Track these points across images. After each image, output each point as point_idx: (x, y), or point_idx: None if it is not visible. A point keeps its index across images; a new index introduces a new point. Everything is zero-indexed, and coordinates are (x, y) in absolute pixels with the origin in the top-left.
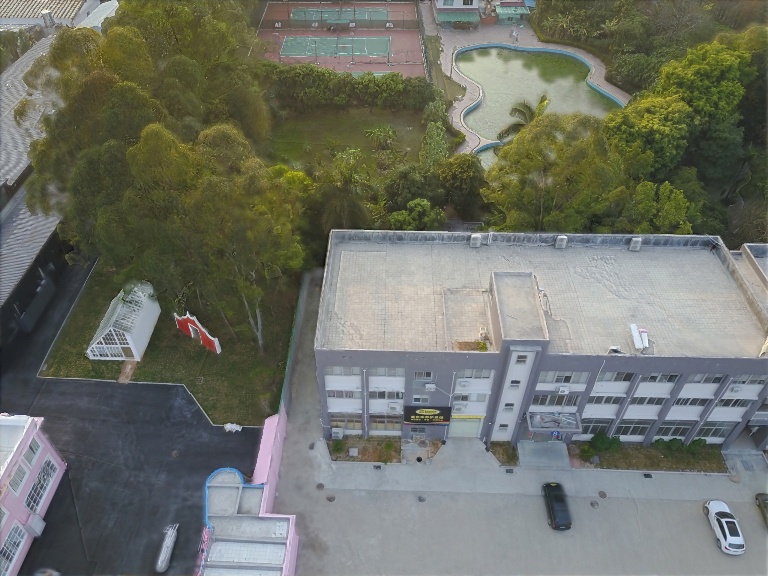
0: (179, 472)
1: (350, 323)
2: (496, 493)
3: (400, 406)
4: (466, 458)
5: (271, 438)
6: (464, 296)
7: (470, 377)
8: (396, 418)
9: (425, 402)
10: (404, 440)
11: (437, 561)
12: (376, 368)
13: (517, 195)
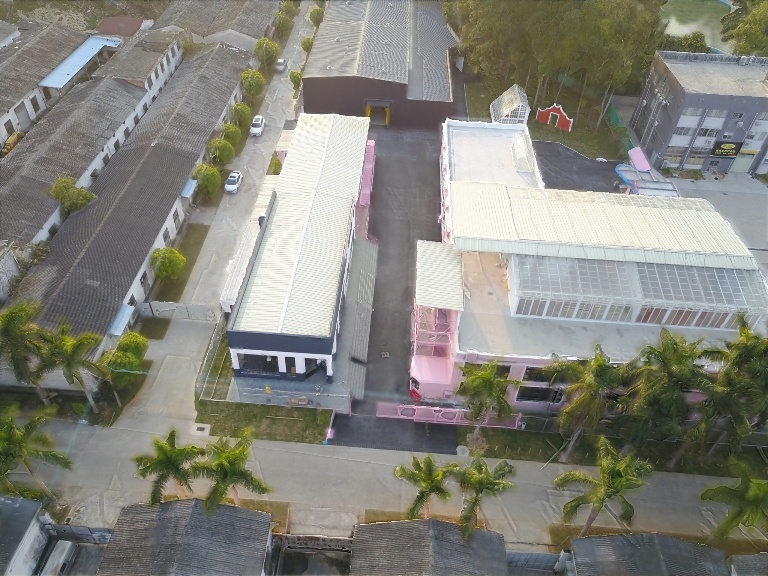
0: (583, 175)
1: (692, 89)
2: (766, 194)
3: (713, 141)
4: (742, 180)
5: (641, 155)
6: (749, 83)
7: (762, 119)
8: (704, 154)
9: (729, 139)
10: (703, 171)
11: (745, 215)
12: (712, 110)
13: (759, 41)
